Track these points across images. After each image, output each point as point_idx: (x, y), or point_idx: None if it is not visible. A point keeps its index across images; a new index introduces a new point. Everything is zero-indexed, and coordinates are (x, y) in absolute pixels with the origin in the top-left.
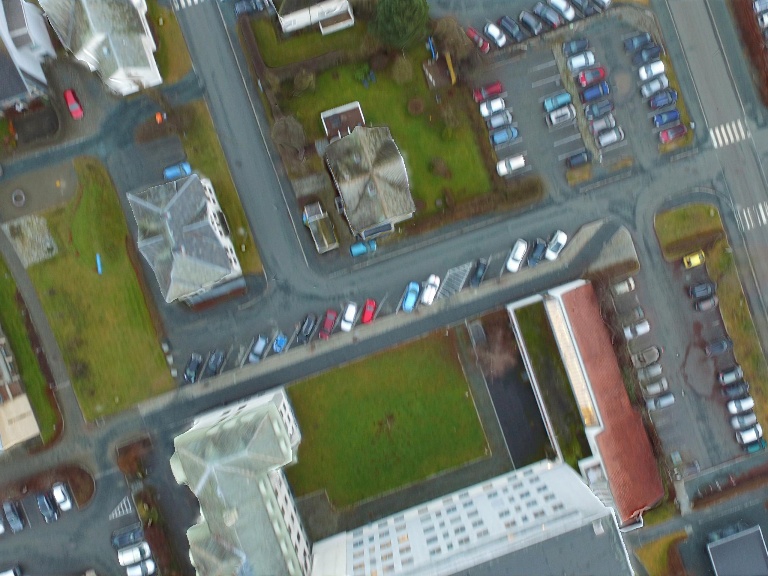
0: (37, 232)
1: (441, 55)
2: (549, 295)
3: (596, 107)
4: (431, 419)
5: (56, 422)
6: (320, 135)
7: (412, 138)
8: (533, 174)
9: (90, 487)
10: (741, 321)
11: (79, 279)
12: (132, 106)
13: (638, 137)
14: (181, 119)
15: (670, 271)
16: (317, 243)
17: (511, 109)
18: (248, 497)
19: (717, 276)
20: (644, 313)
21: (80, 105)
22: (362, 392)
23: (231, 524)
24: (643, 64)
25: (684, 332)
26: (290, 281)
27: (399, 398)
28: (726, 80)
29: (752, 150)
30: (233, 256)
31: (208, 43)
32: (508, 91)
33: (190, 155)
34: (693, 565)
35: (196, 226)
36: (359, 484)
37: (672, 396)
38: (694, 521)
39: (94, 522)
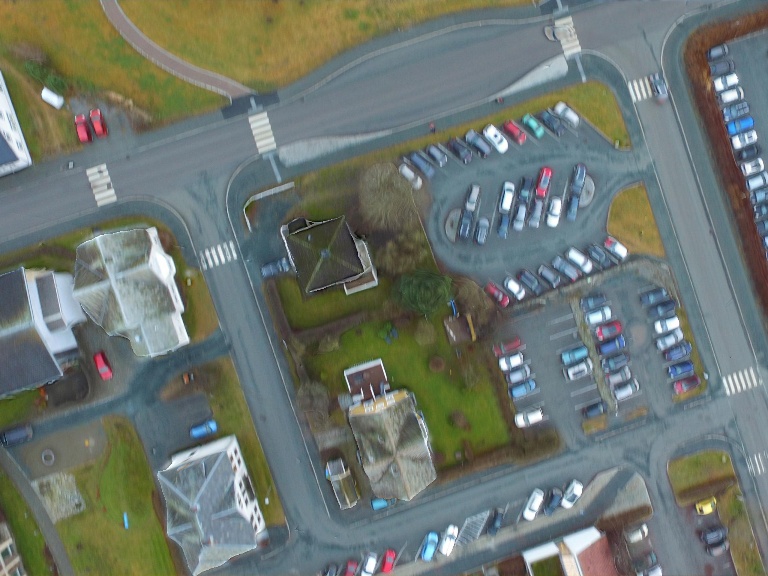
0: (66, 489)
1: (462, 315)
2: (565, 545)
3: (612, 361)
4: None
5: None
6: (343, 390)
7: (433, 392)
8: (550, 424)
9: None
10: (751, 563)
11: (106, 534)
12: (160, 365)
13: (653, 387)
14: (208, 380)
15: (682, 516)
16: (339, 500)
17: (529, 361)
18: None
19: (728, 521)
20: (657, 558)
21: (109, 366)
22: None
23: None
24: (659, 318)
25: (695, 574)
26: (312, 531)
27: None
28: (739, 329)
29: (764, 397)
30: (257, 514)
31: (235, 301)
32: (527, 344)
33: (216, 412)
34: None
35: (224, 514)
36: None
37: None
38: None
39: None
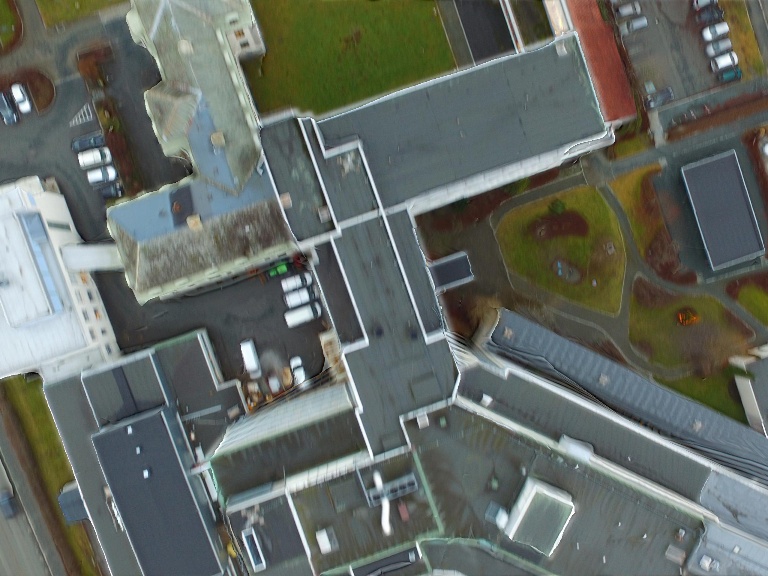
0: None
1: None
2: None
3: None
4: (399, 38)
5: (15, 24)
6: None
7: None
8: None
9: (50, 92)
10: None
11: None
12: None
13: None
14: None
15: None
16: None
17: None
18: (204, 39)
19: None
20: None
21: None
22: (328, 6)
23: (185, 49)
24: None
25: None
26: None
27: (366, 14)
28: None
29: None
30: None
31: None
32: None
33: None
34: (667, 199)
35: None
36: (325, 102)
37: (645, 18)
38: (668, 153)
39: (54, 128)
